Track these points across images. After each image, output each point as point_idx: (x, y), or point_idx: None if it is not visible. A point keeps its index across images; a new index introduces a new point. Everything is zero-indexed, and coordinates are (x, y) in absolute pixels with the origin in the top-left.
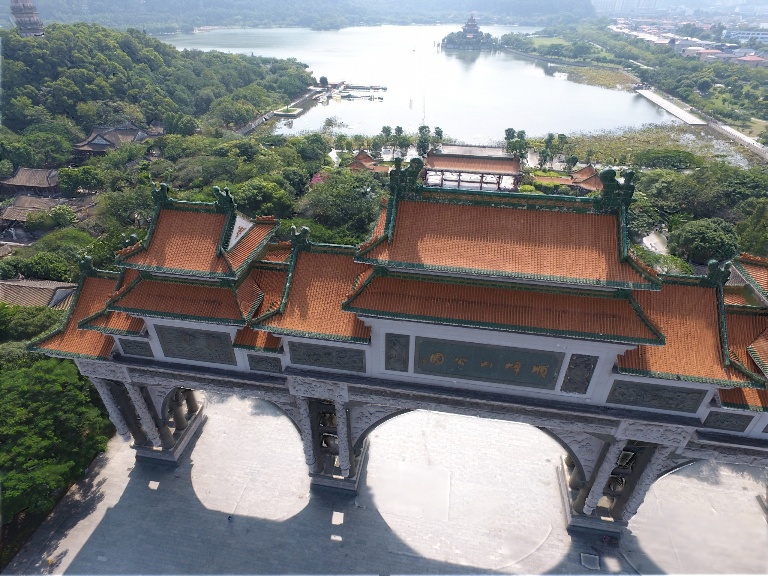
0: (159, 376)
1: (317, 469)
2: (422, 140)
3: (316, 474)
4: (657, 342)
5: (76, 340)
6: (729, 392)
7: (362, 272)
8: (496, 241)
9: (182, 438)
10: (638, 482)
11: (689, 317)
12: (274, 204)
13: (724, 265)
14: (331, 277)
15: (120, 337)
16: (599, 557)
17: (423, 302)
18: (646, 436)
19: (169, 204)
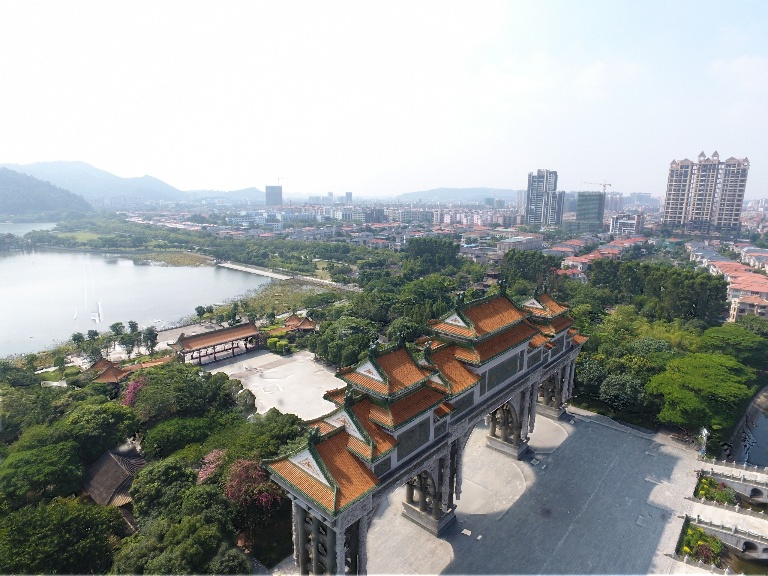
0: (388, 487)
1: (439, 515)
2: (147, 332)
3: (440, 519)
4: (540, 332)
5: (351, 488)
6: (546, 346)
7: (453, 354)
8: (493, 316)
9: None
10: (532, 408)
11: None
12: (130, 420)
13: (523, 306)
14: (447, 362)
15: (376, 464)
16: (534, 459)
17: (492, 349)
18: None
19: (377, 354)
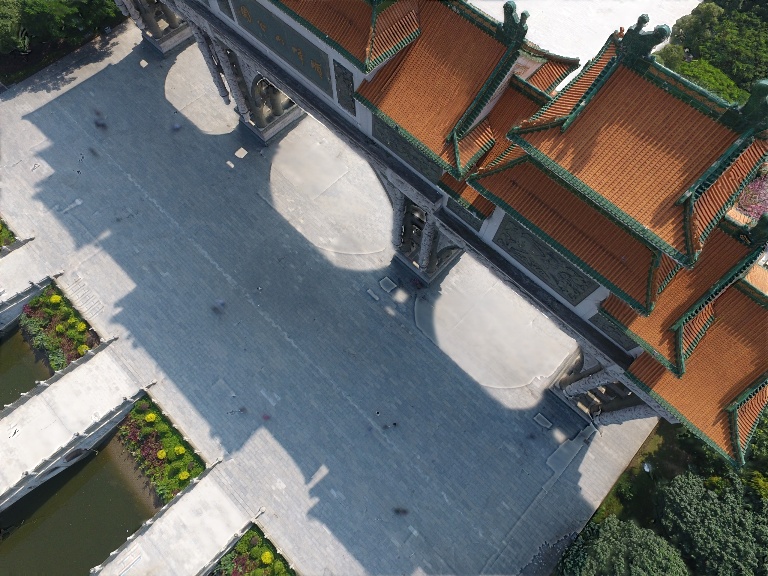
0: None
1: None
2: None
3: (238, 111)
4: (362, 68)
5: None
6: None
7: None
8: None
9: (170, 35)
10: None
11: (459, 72)
12: None
13: None
14: None
15: None
16: (397, 287)
17: None
18: (407, 191)
19: None
